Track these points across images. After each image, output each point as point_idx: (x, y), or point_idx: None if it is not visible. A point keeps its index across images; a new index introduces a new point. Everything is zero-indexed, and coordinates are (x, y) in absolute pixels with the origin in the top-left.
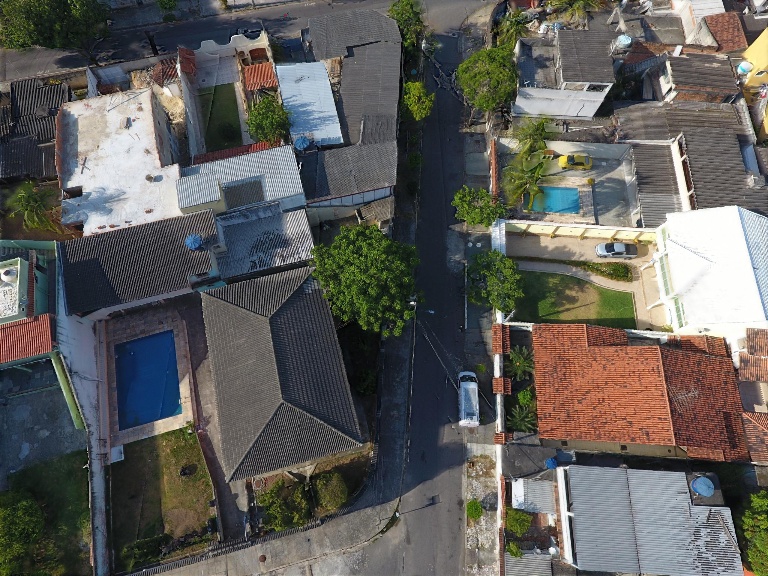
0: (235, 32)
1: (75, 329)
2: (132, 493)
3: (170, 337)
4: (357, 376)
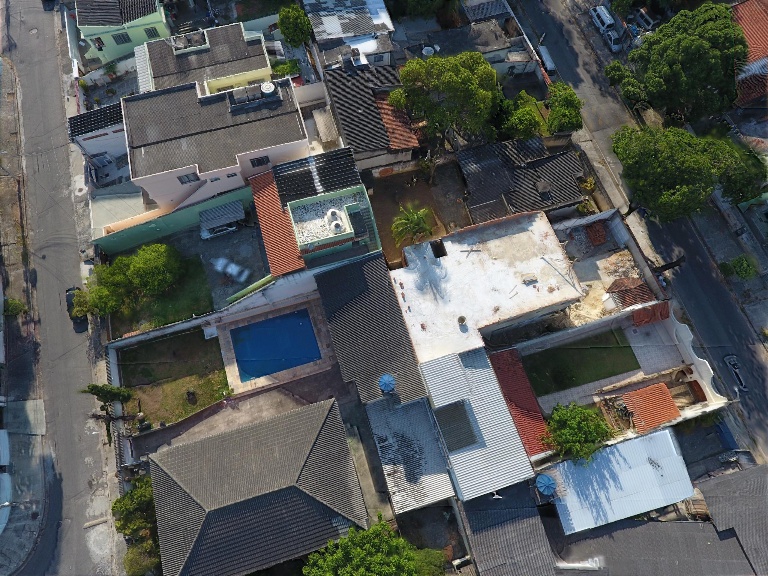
0: (729, 352)
1: (307, 281)
2: (177, 352)
3: (316, 356)
4: (260, 574)
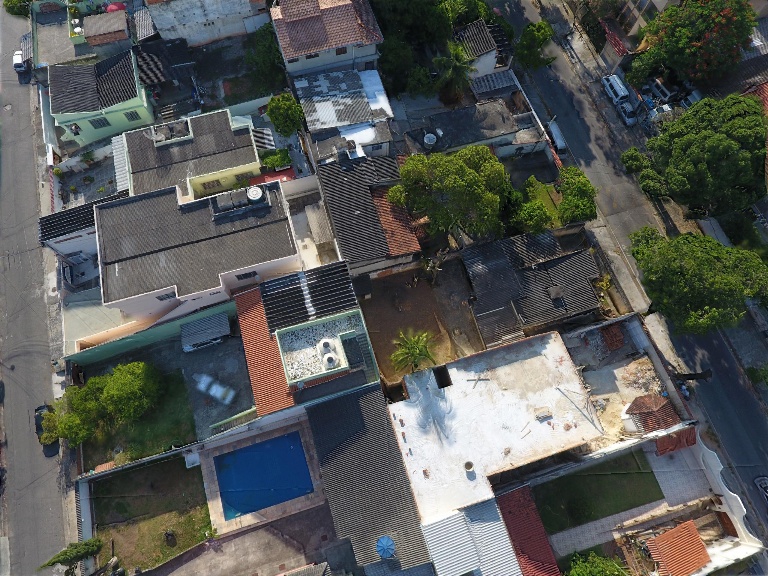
0: (760, 473)
1: (297, 410)
2: (156, 485)
3: (308, 486)
4: None
